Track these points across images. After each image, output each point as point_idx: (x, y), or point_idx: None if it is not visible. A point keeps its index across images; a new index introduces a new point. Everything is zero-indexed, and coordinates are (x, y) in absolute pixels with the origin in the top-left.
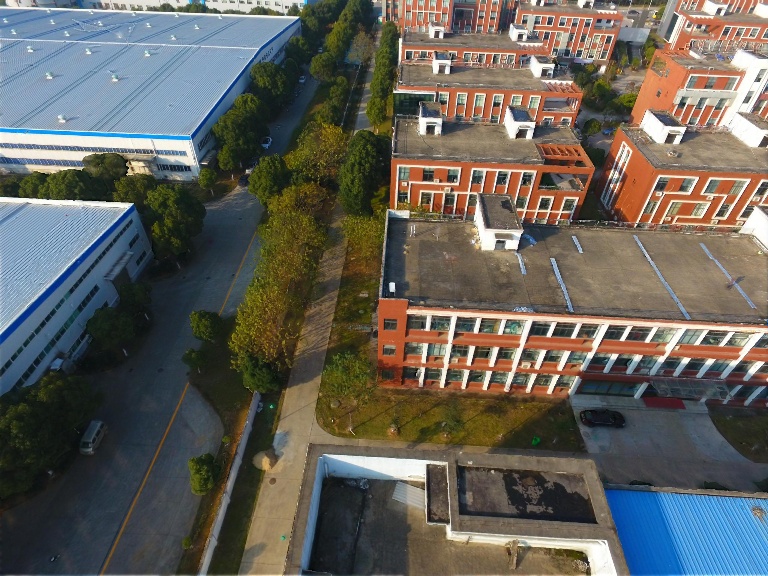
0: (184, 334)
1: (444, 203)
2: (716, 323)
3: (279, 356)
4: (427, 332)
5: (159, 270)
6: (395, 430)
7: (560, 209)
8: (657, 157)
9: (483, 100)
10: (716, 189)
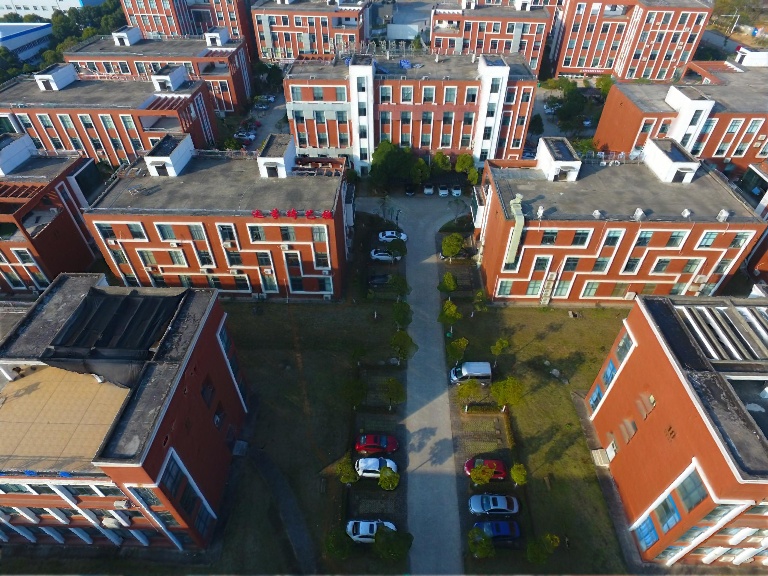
0: None
1: None
2: None
3: None
4: None
5: None
6: None
7: (19, 261)
8: (119, 196)
9: (70, 121)
10: (174, 235)
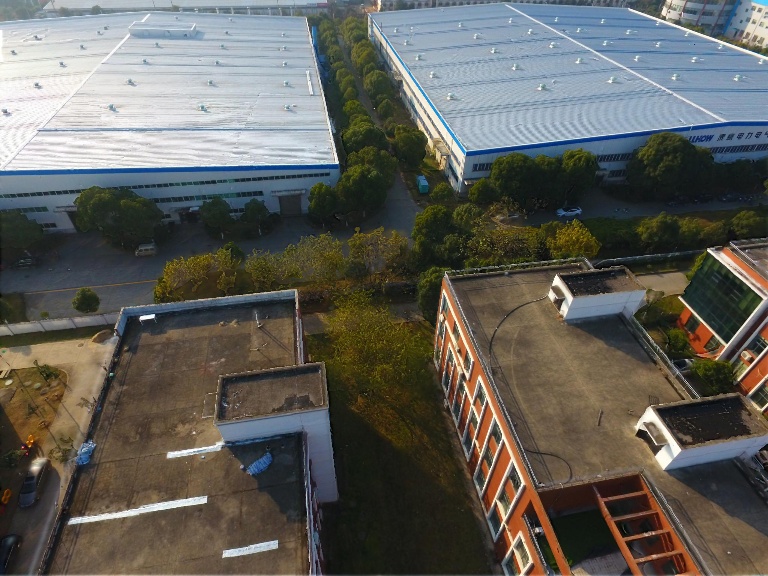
0: (246, 257)
1: (459, 385)
2: None
3: None
4: None
5: (311, 217)
6: None
7: None
8: None
9: None
10: None
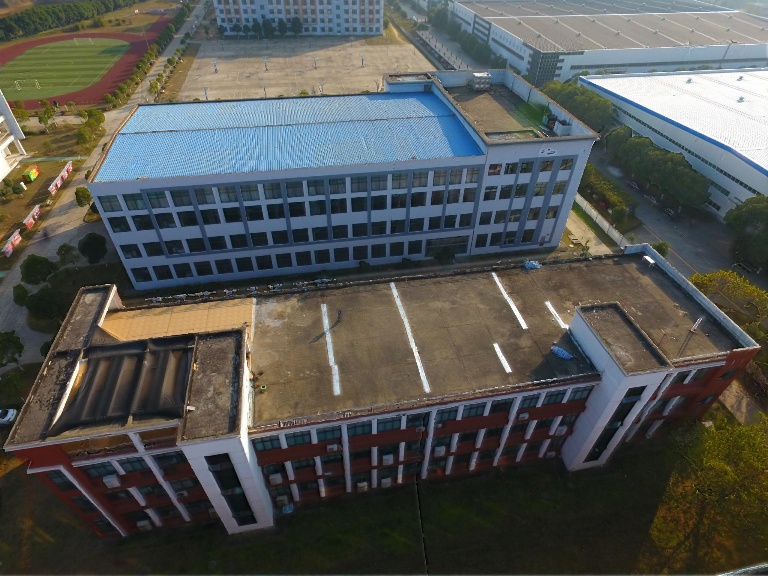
0: None
1: None
2: (370, 281)
3: None
4: None
5: None
6: None
7: None
8: None
9: None
10: None
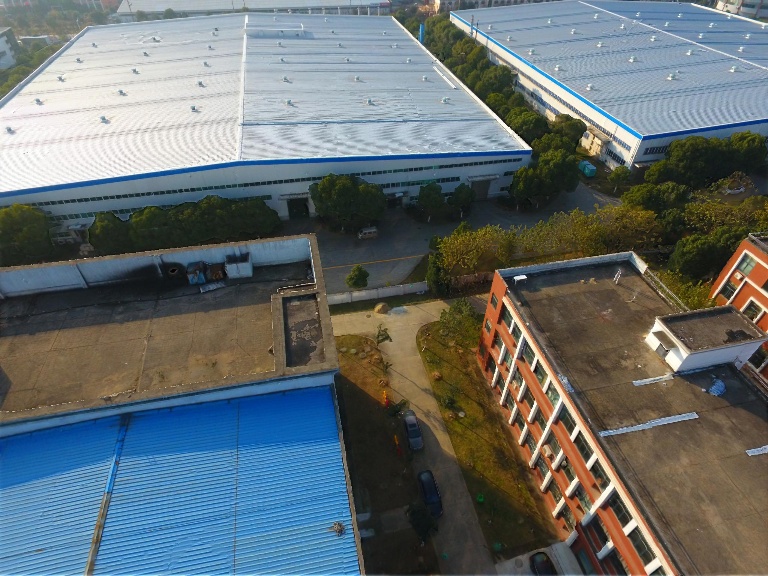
0: None
1: None
2: None
3: (468, 287)
4: (509, 334)
5: (504, 200)
6: (438, 376)
7: None
8: None
9: None
10: None
